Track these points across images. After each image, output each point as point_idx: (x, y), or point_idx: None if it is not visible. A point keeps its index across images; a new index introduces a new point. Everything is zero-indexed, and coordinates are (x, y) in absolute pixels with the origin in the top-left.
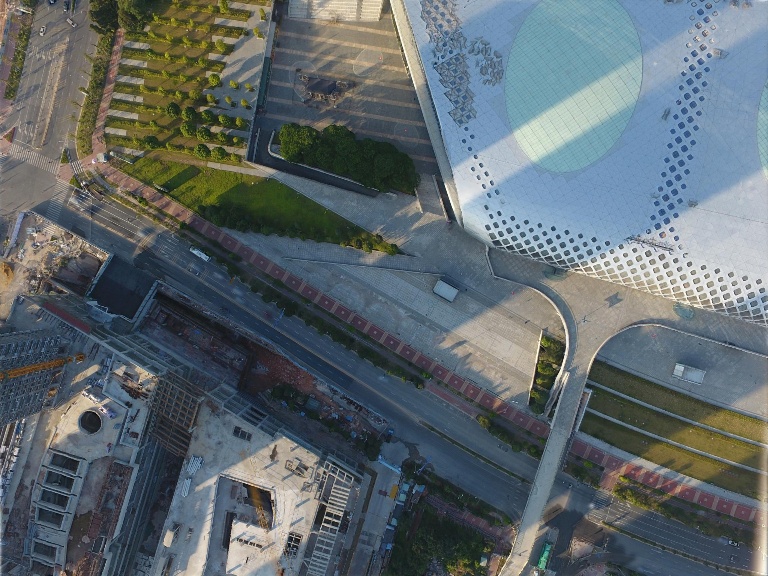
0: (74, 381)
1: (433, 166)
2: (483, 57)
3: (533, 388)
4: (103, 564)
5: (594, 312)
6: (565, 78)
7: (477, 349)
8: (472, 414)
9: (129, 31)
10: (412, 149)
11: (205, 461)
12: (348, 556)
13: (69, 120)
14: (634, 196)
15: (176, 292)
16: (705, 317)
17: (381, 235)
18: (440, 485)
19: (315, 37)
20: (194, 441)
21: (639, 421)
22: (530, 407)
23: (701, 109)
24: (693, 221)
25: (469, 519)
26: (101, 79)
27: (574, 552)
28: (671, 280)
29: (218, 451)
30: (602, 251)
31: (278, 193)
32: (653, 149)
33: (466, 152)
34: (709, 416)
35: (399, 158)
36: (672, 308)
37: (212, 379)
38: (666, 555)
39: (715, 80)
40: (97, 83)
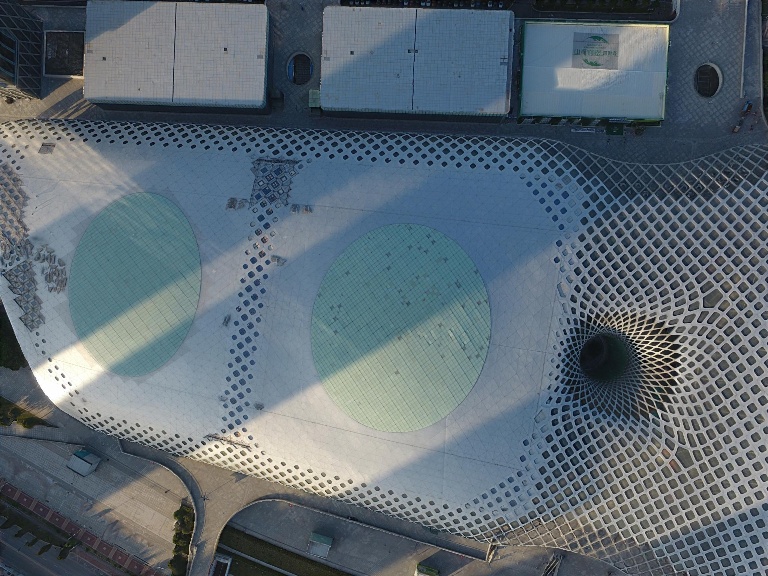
0: None
1: None
2: (48, 265)
3: (174, 557)
4: None
5: (221, 487)
6: (124, 287)
7: (122, 517)
8: None
9: None
10: None
11: None
12: None
13: None
14: (203, 399)
15: None
16: None
17: (25, 406)
18: None
19: None
20: None
21: None
22: None
23: (260, 316)
24: (262, 423)
25: None
26: None
27: None
28: (261, 472)
29: None
30: (189, 445)
31: None
32: (216, 355)
33: (41, 355)
34: None
35: None
36: None
37: None
38: None
39: (273, 287)
40: None
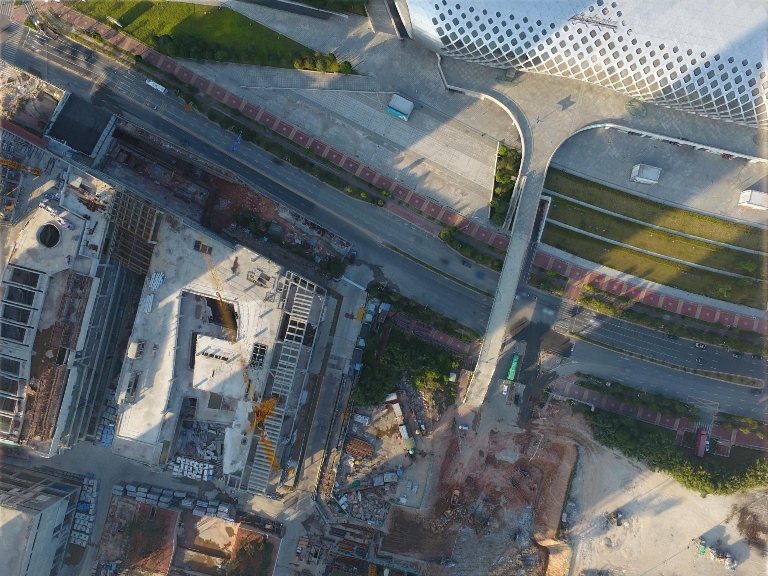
0: (31, 197)
1: None
2: None
3: None
4: (67, 375)
5: (548, 116)
6: None
7: (436, 166)
8: (434, 232)
9: None
10: None
11: (167, 277)
12: (318, 381)
13: None
14: None
15: (134, 127)
16: (658, 115)
17: None
18: (406, 305)
19: None
20: (155, 257)
21: (600, 228)
22: (491, 221)
23: None
24: None
25: (437, 337)
26: None
27: (543, 364)
28: (618, 63)
29: (179, 266)
30: (548, 35)
31: (231, 21)
32: None
33: None
34: (668, 218)
35: None
36: (625, 107)
37: None
38: (634, 361)
39: None
40: None
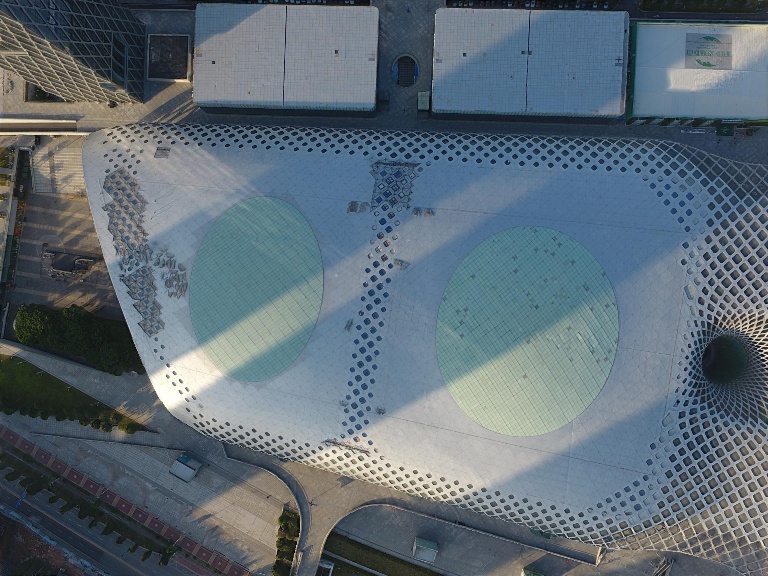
0: None
1: None
2: (168, 270)
3: (276, 562)
4: None
5: (326, 492)
6: (246, 292)
7: (222, 523)
8: None
9: None
10: None
11: None
12: None
13: None
14: (324, 404)
15: None
16: None
17: (124, 411)
18: None
19: (61, 211)
20: None
21: None
22: None
23: (383, 320)
24: (383, 427)
25: None
26: None
27: None
28: (377, 477)
29: None
30: (305, 451)
31: (22, 371)
32: (338, 359)
33: (159, 361)
34: None
35: (125, 345)
36: None
37: None
38: None
39: (396, 291)
40: None
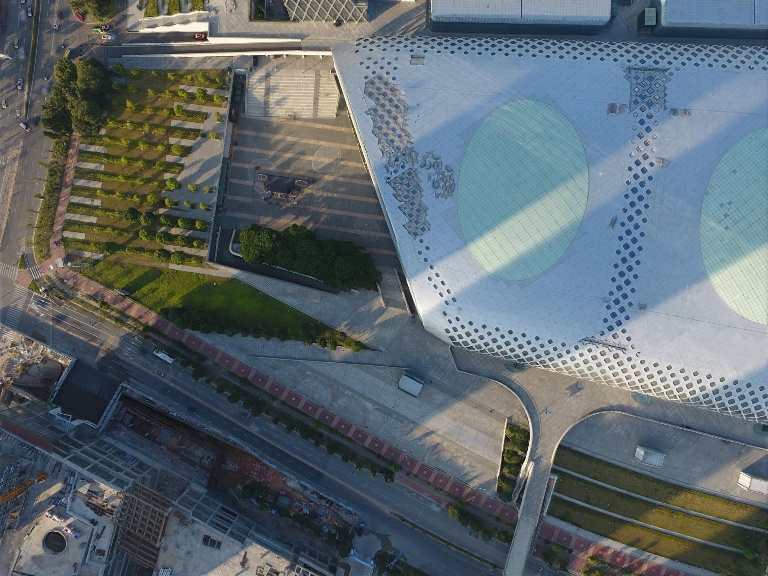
0: (37, 501)
1: (394, 259)
2: (435, 171)
3: (500, 476)
4: None
5: (556, 401)
6: (515, 191)
7: (444, 439)
8: (442, 503)
9: (84, 135)
10: (373, 243)
11: (175, 572)
12: None
13: (26, 225)
14: (586, 301)
15: (141, 394)
16: (662, 402)
17: (345, 331)
18: (413, 575)
19: (273, 135)
20: (163, 552)
21: (604, 503)
22: (498, 494)
23: (646, 216)
24: (643, 323)
25: None
26: (57, 183)
27: None
28: (626, 376)
29: (188, 561)
30: (559, 351)
31: (241, 293)
32: (602, 256)
33: (422, 263)
34: (671, 495)
35: (359, 259)
36: (630, 395)
37: (181, 479)
38: None
39: (658, 188)
40: (53, 188)
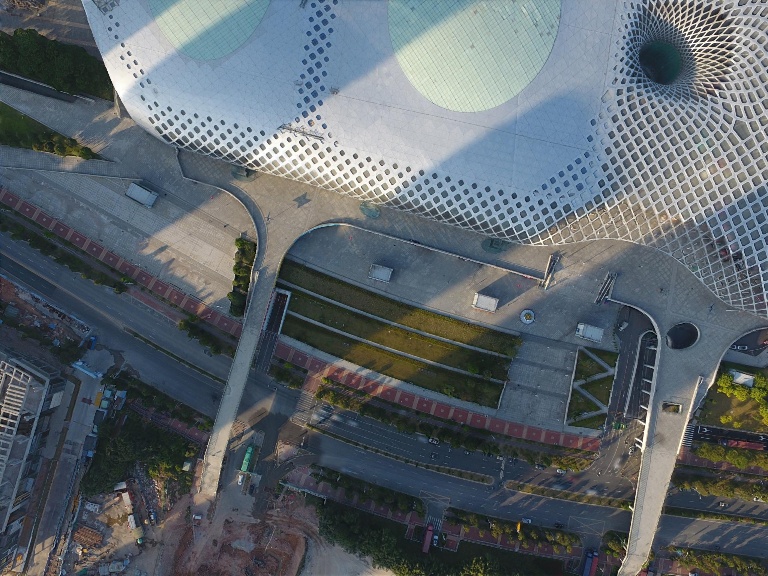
0: None
1: None
2: None
3: (233, 291)
4: None
5: (283, 212)
6: None
7: (179, 254)
8: (177, 320)
9: None
10: None
11: None
12: (51, 466)
13: None
14: (279, 84)
15: None
16: (391, 216)
17: (80, 141)
18: None
19: None
20: None
21: (339, 323)
22: None
23: None
24: (337, 108)
25: (175, 425)
26: None
27: (280, 455)
28: (331, 171)
29: None
30: (260, 142)
31: None
32: (293, 37)
33: (113, 40)
34: (405, 316)
35: (81, 58)
36: (359, 208)
37: None
38: (369, 455)
39: None
40: None
